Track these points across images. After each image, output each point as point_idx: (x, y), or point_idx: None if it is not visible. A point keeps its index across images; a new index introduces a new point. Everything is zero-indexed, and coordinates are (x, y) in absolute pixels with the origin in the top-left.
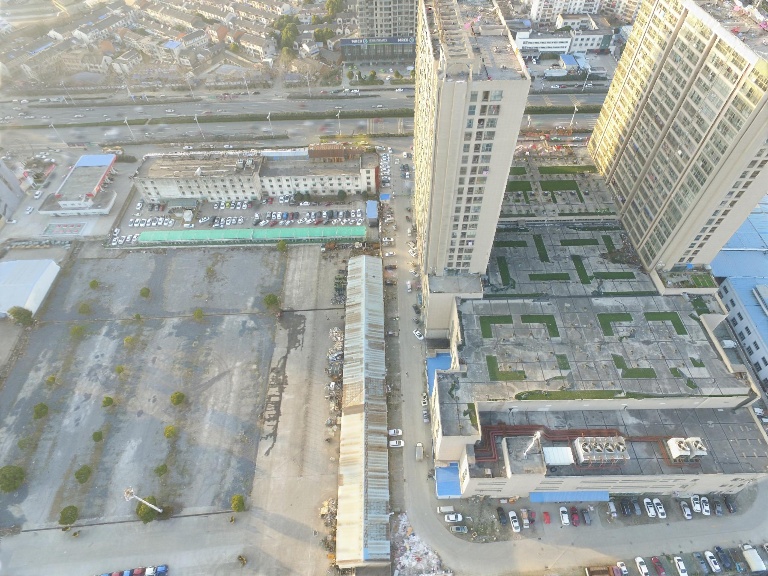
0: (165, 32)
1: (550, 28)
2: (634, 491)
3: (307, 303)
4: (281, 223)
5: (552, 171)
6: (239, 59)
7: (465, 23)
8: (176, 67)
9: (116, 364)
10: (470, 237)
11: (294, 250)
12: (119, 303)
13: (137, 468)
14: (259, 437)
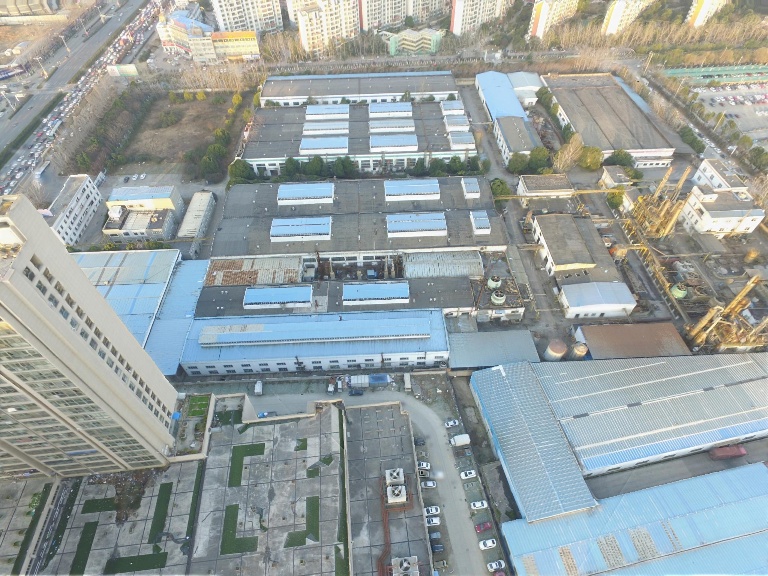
0: None
1: None
2: None
3: None
4: None
5: None
6: None
7: None
8: None
9: None
10: None
11: None
12: None
13: None
14: None
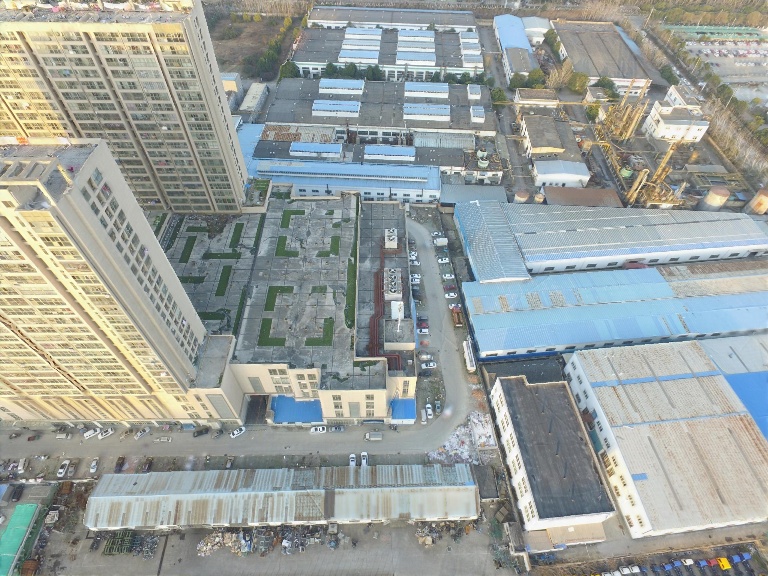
0: None
1: None
2: None
3: None
4: None
5: None
6: None
7: None
8: None
9: None
10: (180, 318)
11: None
12: None
13: None
14: None
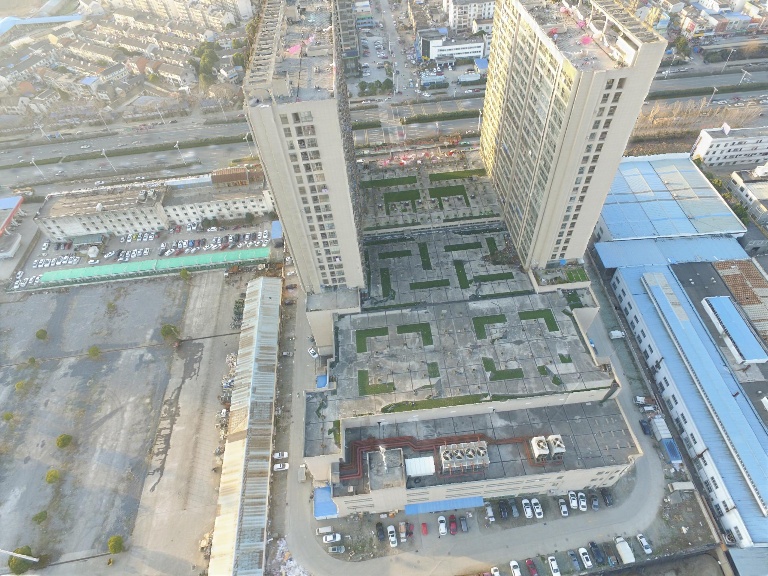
0: (85, 68)
1: (467, 34)
2: (505, 494)
3: (206, 330)
4: (186, 251)
5: (442, 178)
6: (157, 89)
7: None
8: (93, 102)
9: (7, 411)
10: (335, 253)
11: (198, 277)
12: (16, 347)
13: (19, 517)
14: (146, 473)
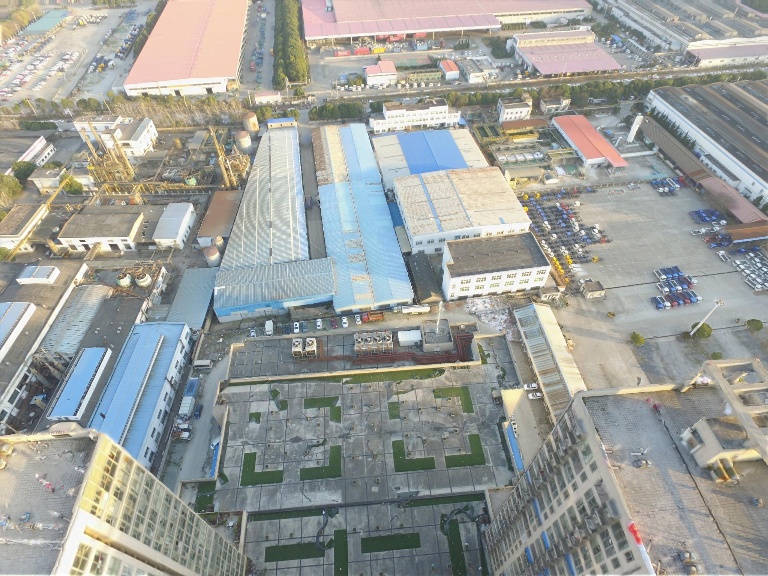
0: None
1: None
2: None
3: None
4: None
5: None
6: None
7: None
8: None
9: None
10: None
11: None
12: None
13: None
14: None
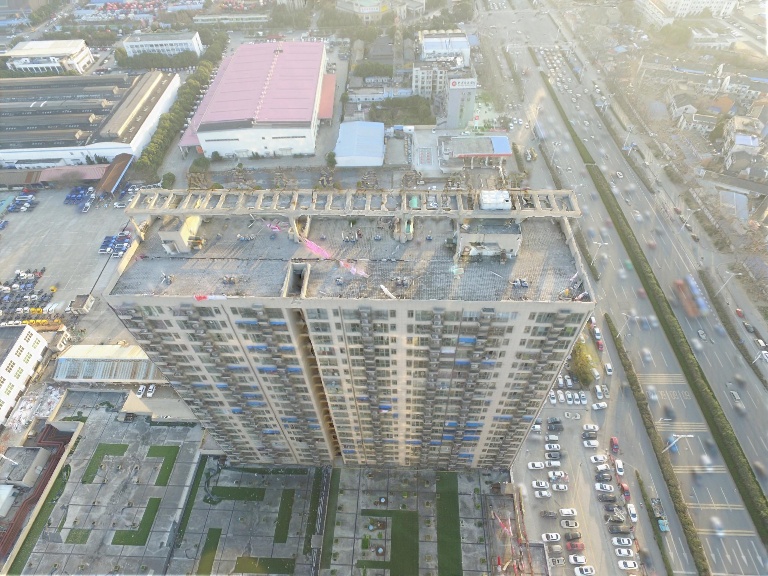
0: None
1: None
2: None
3: None
4: None
5: None
6: None
7: (347, 255)
8: (708, 158)
9: None
10: None
11: None
12: None
13: None
14: None
